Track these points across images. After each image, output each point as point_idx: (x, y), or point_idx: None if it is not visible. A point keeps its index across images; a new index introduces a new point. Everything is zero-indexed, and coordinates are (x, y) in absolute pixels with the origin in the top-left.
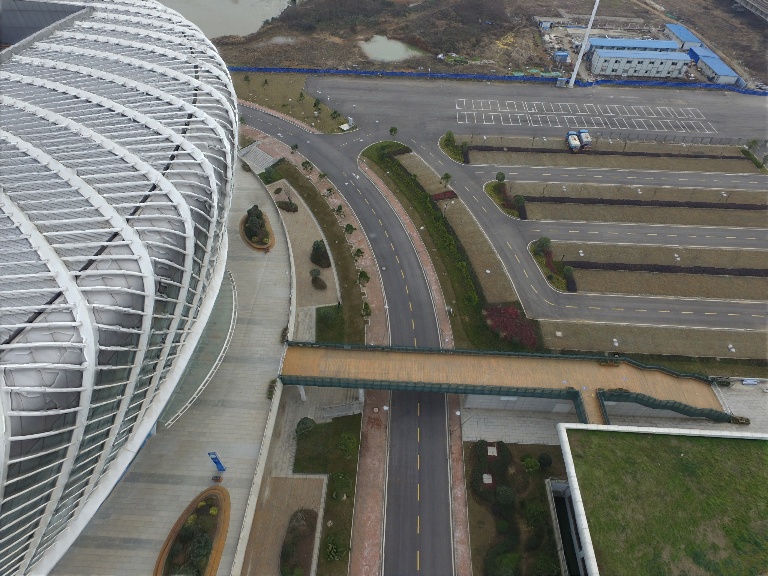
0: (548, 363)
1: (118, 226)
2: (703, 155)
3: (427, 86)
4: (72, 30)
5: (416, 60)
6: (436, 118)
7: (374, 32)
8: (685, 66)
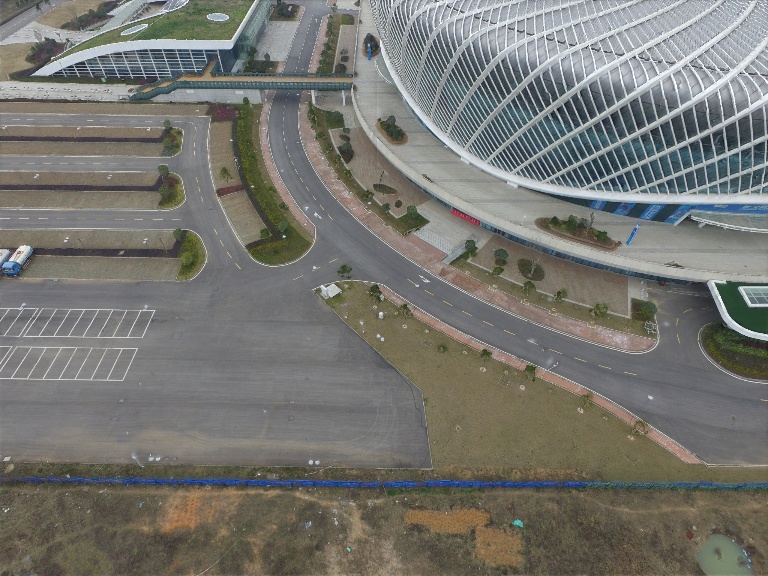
0: None
1: None
2: None
3: (160, 432)
4: None
5: None
6: (186, 318)
7: None
8: None
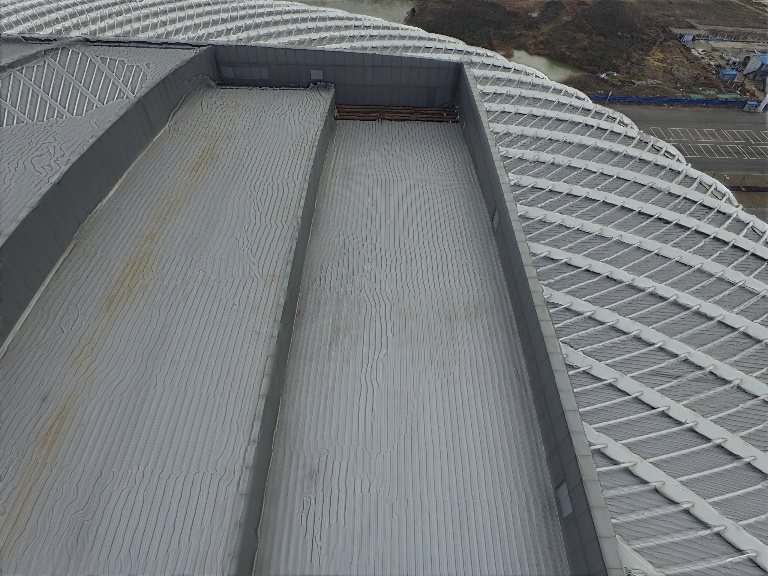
0: None
1: None
2: None
3: None
4: (487, 99)
5: (578, 80)
6: None
7: (513, 47)
8: None
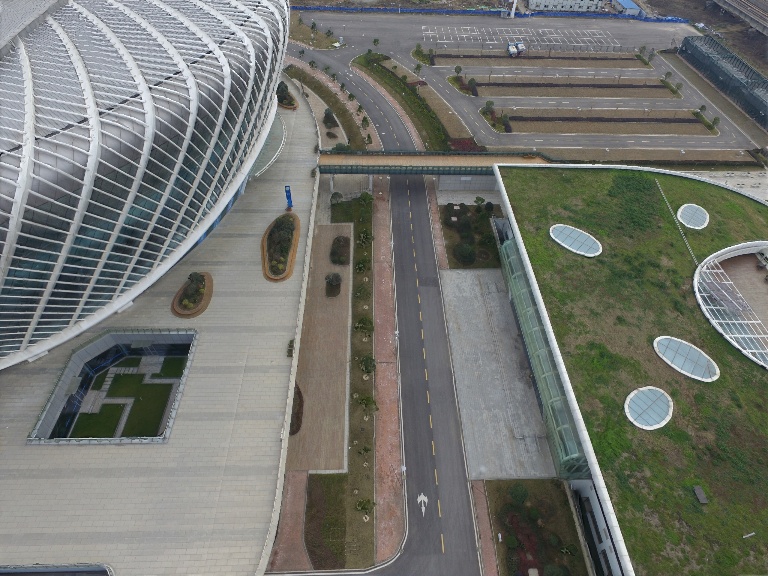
0: (491, 158)
1: (249, 14)
2: (607, 58)
3: (399, 18)
4: None
5: (388, 1)
6: (408, 38)
7: None
8: (600, 2)
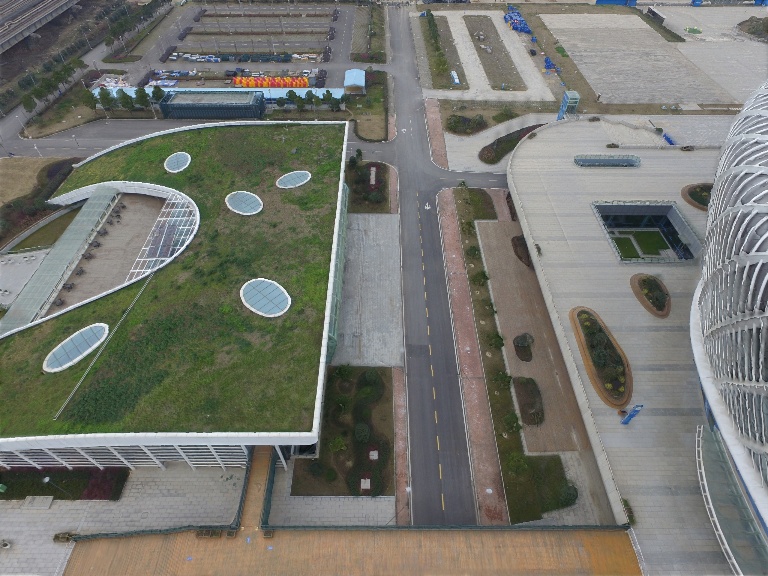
0: None
1: None
2: None
3: None
4: None
5: None
6: None
7: None
8: None
